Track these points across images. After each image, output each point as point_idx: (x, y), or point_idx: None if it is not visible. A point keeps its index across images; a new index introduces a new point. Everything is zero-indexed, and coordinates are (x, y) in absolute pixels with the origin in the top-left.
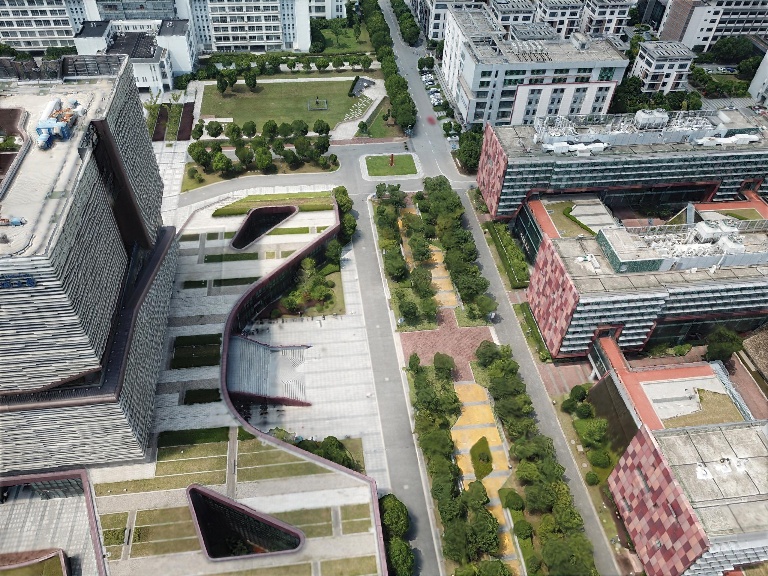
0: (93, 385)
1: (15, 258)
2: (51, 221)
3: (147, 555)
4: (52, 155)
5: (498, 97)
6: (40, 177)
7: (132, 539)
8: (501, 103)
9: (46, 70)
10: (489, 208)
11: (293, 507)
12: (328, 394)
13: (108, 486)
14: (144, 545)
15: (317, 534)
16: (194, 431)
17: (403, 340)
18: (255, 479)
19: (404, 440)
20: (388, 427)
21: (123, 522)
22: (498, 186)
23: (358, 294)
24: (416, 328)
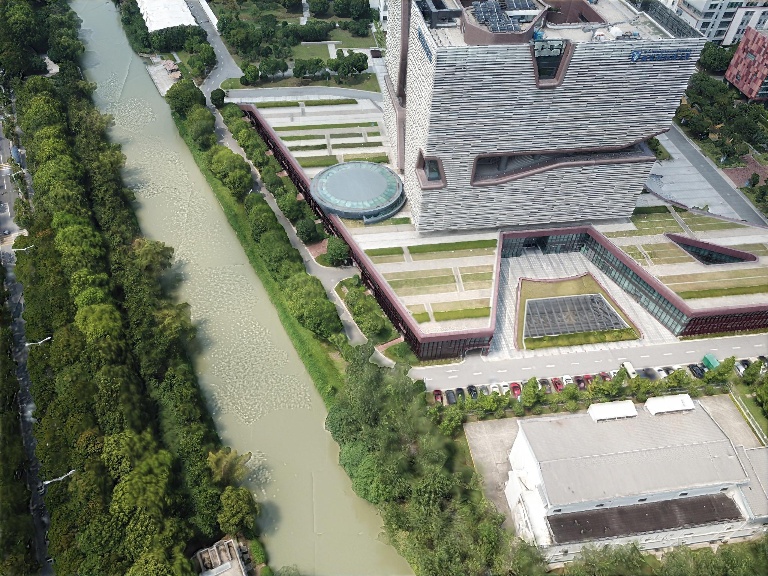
0: (637, 152)
1: (691, 38)
2: (654, 34)
3: (664, 264)
4: (602, 6)
5: (720, 18)
6: (613, 16)
7: (649, 256)
8: (720, 23)
9: (338, 3)
10: (747, 93)
11: (738, 243)
12: (694, 202)
13: (612, 233)
14: (658, 259)
15: (763, 255)
16: (646, 207)
17: (726, 173)
18: (703, 230)
19: (762, 225)
20: (747, 219)
21: (636, 249)
22: (765, 72)
23: (675, 148)
24: (732, 166)
